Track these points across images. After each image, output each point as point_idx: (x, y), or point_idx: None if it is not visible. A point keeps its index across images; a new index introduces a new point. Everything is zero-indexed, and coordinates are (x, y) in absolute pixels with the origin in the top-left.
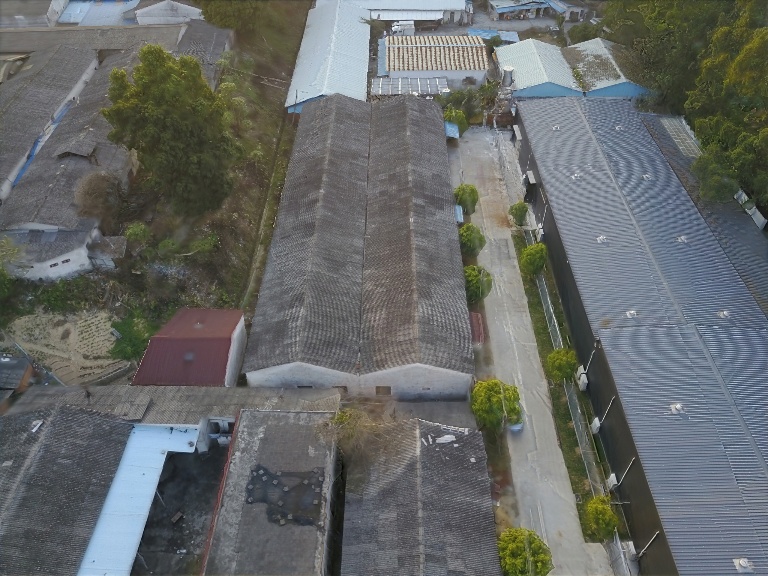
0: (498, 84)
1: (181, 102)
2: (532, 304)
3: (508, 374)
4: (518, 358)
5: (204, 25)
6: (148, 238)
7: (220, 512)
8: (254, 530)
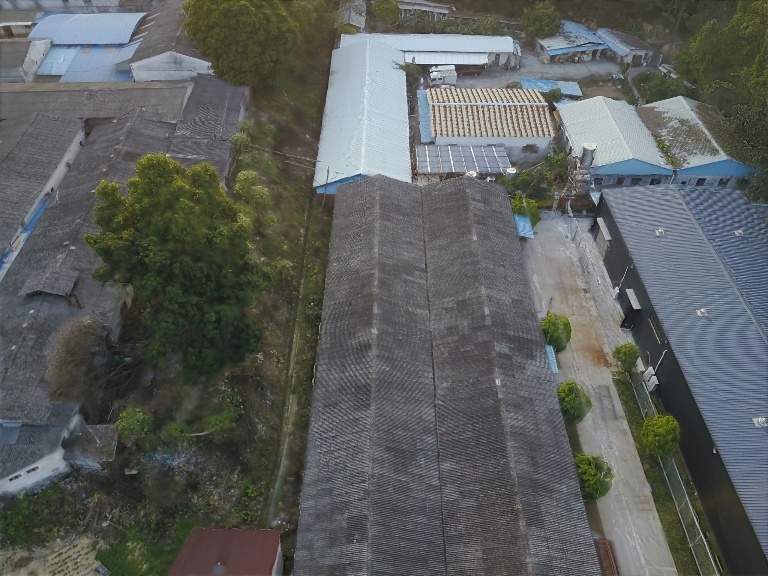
0: (567, 155)
1: (194, 235)
2: (658, 497)
3: None
4: None
5: (214, 81)
6: None
7: None
8: None
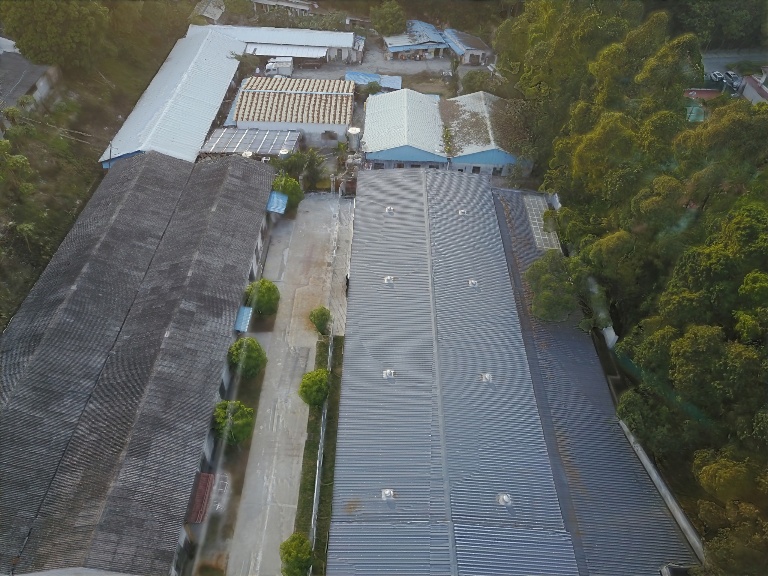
0: None
1: None
2: (310, 445)
3: (245, 553)
4: (266, 528)
5: (18, 60)
6: None
7: None
8: None
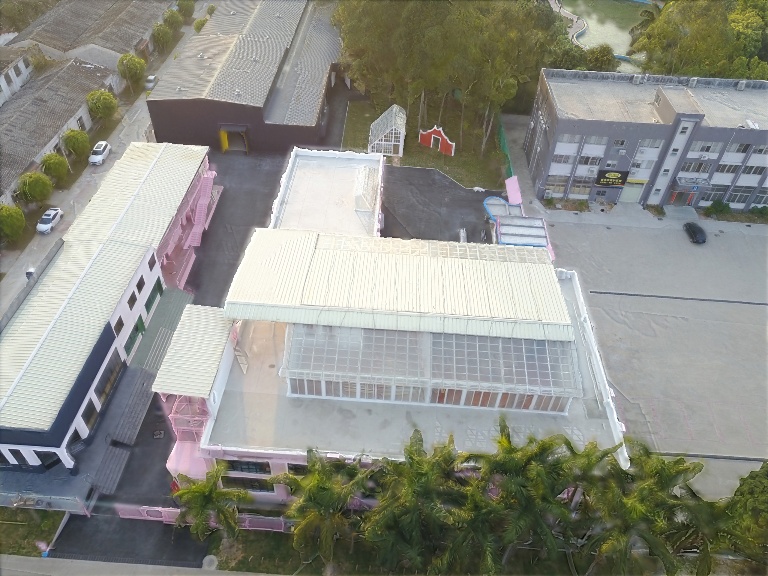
0: None
1: None
2: None
3: (162, 74)
4: None
5: None
6: None
7: None
8: None
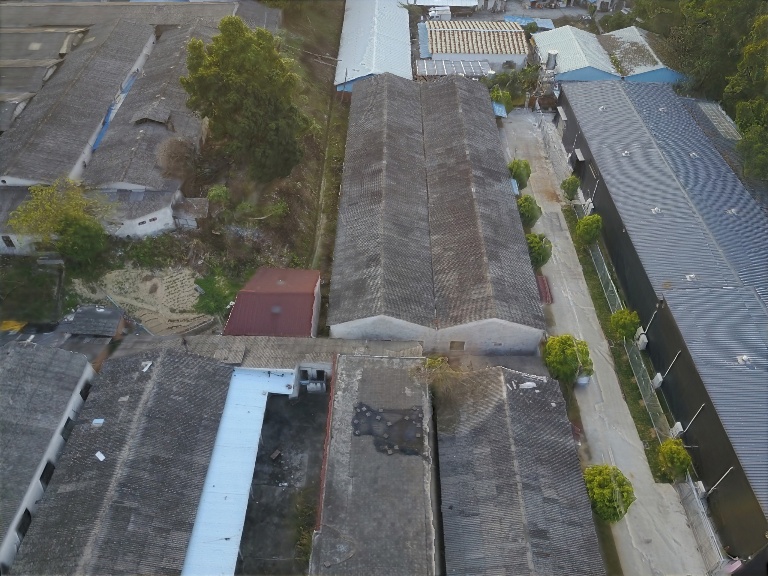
0: (538, 68)
1: (260, 71)
2: (587, 272)
3: (570, 334)
4: (578, 320)
5: (254, 4)
6: (225, 201)
7: (331, 443)
8: (365, 458)
